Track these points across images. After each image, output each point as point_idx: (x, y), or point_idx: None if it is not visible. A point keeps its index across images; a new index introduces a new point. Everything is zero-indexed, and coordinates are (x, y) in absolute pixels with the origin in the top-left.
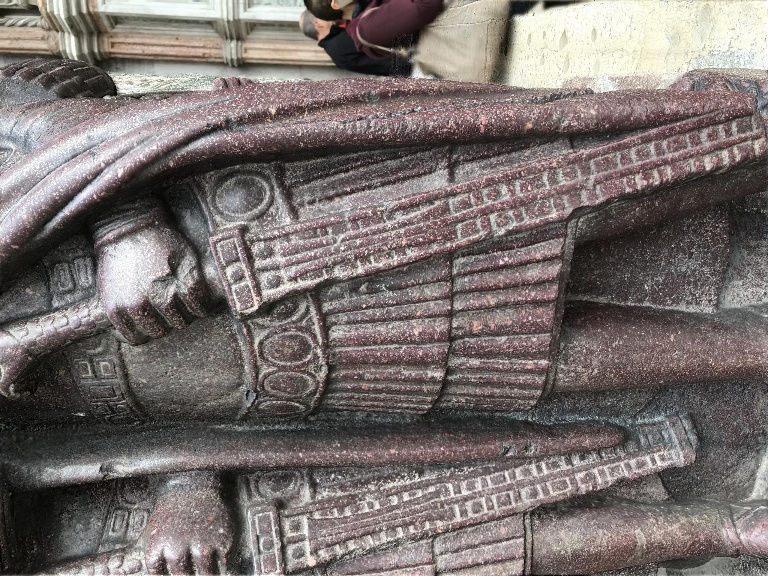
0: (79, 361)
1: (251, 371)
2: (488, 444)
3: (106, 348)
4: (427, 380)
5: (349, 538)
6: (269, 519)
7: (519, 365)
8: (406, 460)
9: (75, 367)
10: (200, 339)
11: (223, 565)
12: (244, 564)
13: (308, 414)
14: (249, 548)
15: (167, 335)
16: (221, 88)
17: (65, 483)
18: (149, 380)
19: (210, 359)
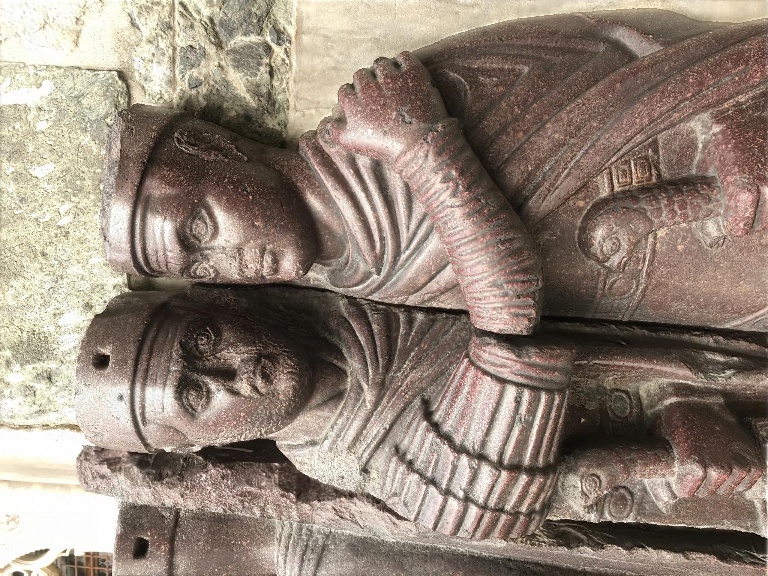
0: None
1: None
2: None
3: None
4: None
5: None
6: None
7: None
8: None
9: None
10: None
11: None
12: None
13: None
14: None
15: None
16: (741, 227)
17: None
18: None
19: None
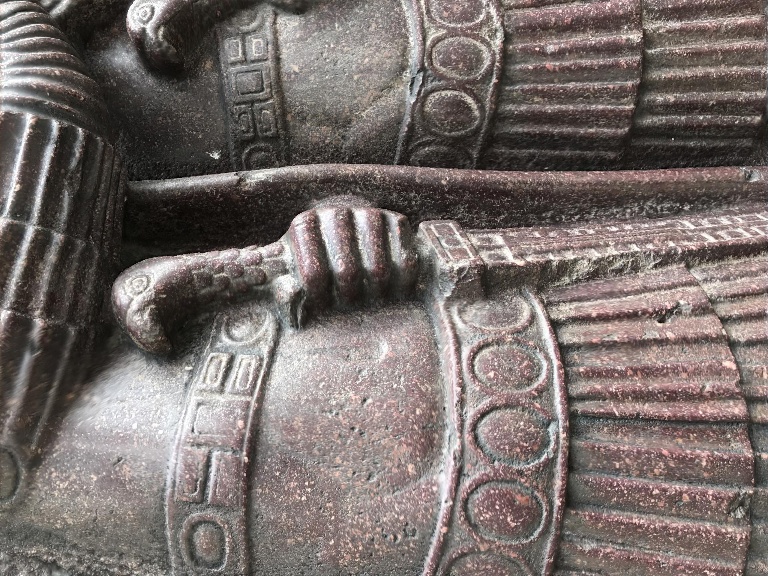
0: (231, 40)
1: (417, 35)
2: (720, 167)
3: (261, 22)
4: (623, 43)
5: (564, 247)
6: (449, 227)
7: (729, 20)
8: (617, 180)
9: (225, 48)
10: (361, 6)
11: (395, 240)
12: (421, 270)
13: (480, 155)
14: (427, 245)
15: (326, 3)
16: None
17: (192, 187)
18: (302, 67)
19: (371, 30)
